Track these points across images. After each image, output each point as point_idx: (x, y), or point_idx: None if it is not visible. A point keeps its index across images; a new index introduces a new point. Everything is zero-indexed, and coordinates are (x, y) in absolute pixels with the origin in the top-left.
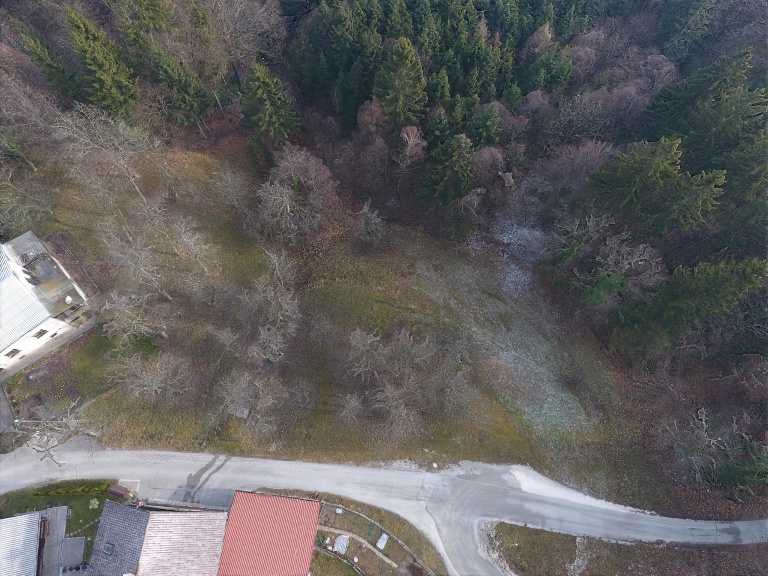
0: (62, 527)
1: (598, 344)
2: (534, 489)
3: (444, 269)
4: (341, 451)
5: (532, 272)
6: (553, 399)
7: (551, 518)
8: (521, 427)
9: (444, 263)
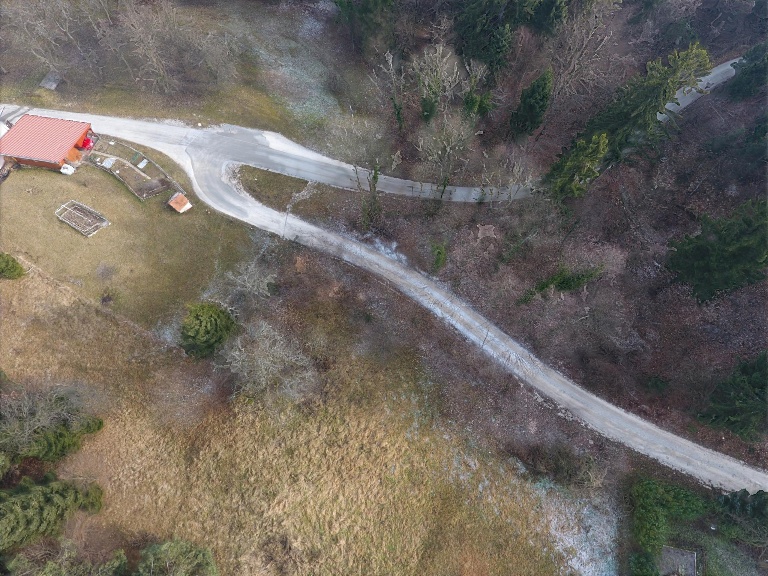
0: None
1: (367, 70)
2: (280, 148)
3: (254, 21)
4: (123, 109)
5: (325, 22)
6: (316, 99)
7: (290, 167)
8: (283, 113)
9: (255, 17)
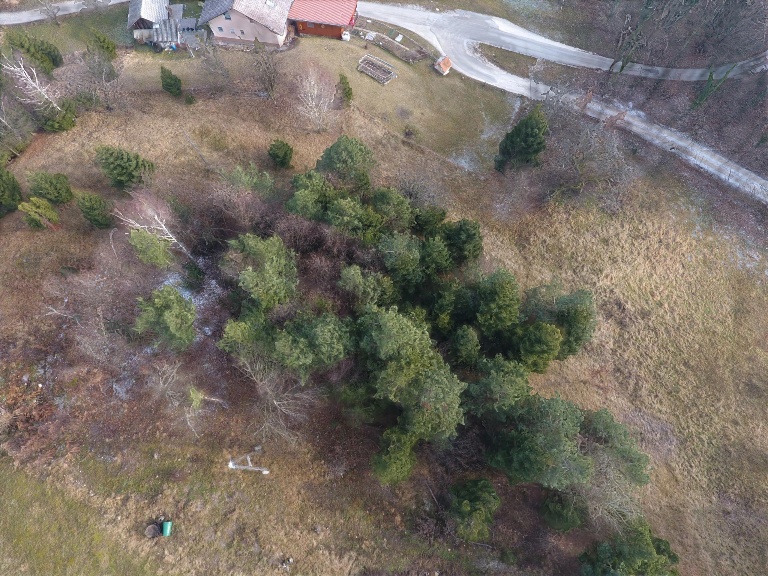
0: (180, 14)
1: None
2: (508, 30)
3: None
4: None
5: None
6: None
7: (520, 46)
8: (501, 4)
9: None
